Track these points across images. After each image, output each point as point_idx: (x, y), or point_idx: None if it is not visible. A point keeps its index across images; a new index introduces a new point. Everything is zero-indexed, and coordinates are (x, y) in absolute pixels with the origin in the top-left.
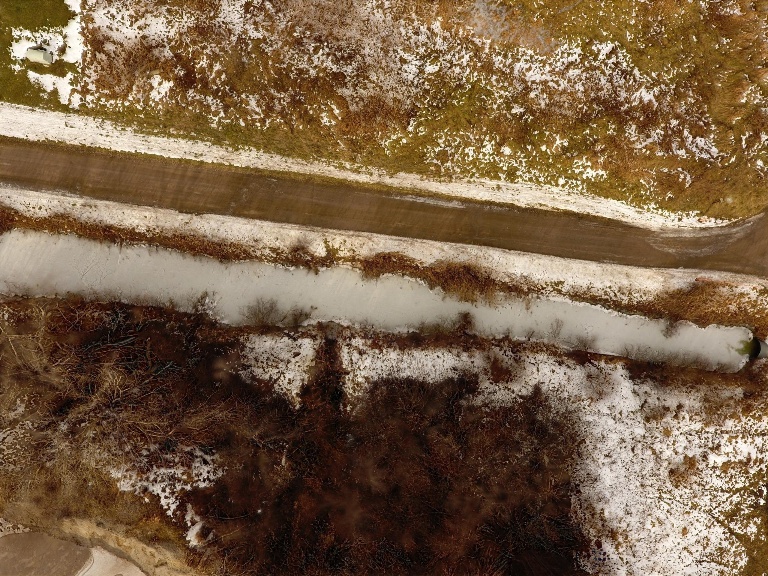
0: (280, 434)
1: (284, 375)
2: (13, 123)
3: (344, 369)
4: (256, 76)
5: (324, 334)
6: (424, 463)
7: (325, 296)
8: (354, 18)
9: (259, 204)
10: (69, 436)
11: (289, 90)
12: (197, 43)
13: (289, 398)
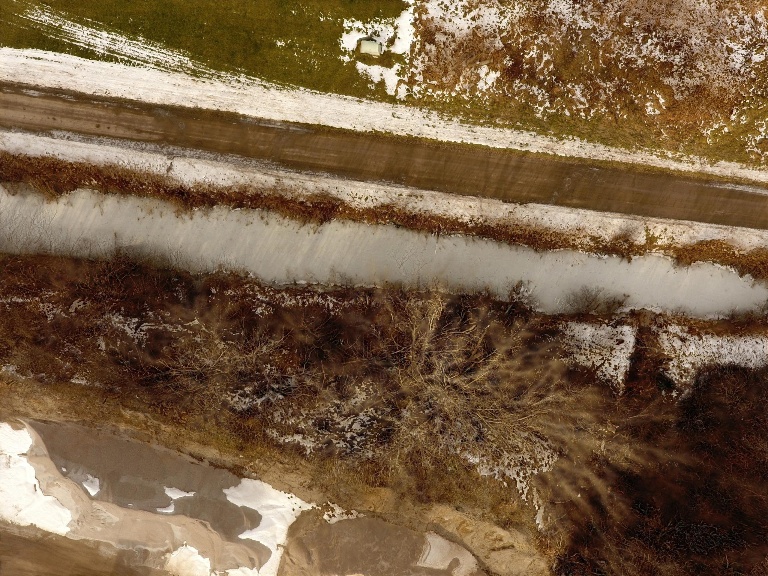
0: (600, 420)
1: (610, 362)
2: (341, 114)
3: (666, 355)
4: (583, 66)
5: (638, 321)
6: (743, 447)
7: (637, 284)
8: (681, 8)
9: (581, 193)
10: (416, 423)
11: (615, 80)
12: (528, 33)
13: (613, 384)
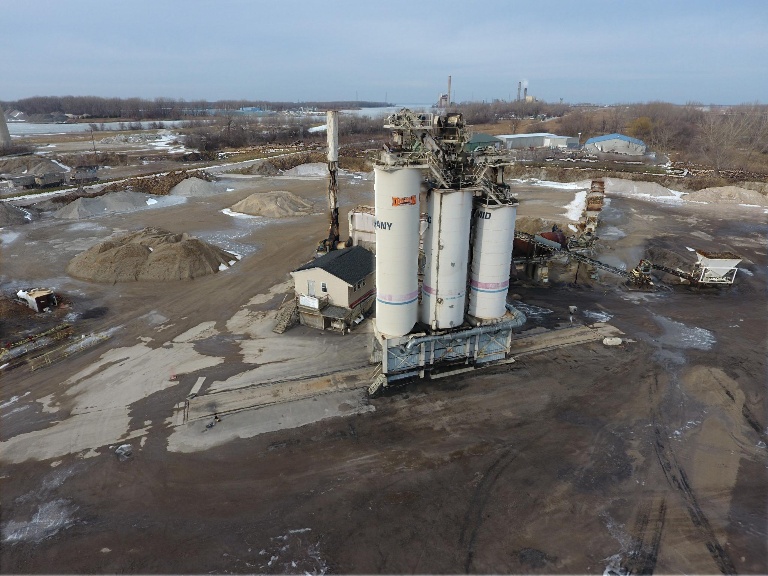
0: None
1: None
2: None
3: None
4: None
5: None
6: None
7: None
8: None
9: None
10: None
11: (765, 177)
12: None
13: None
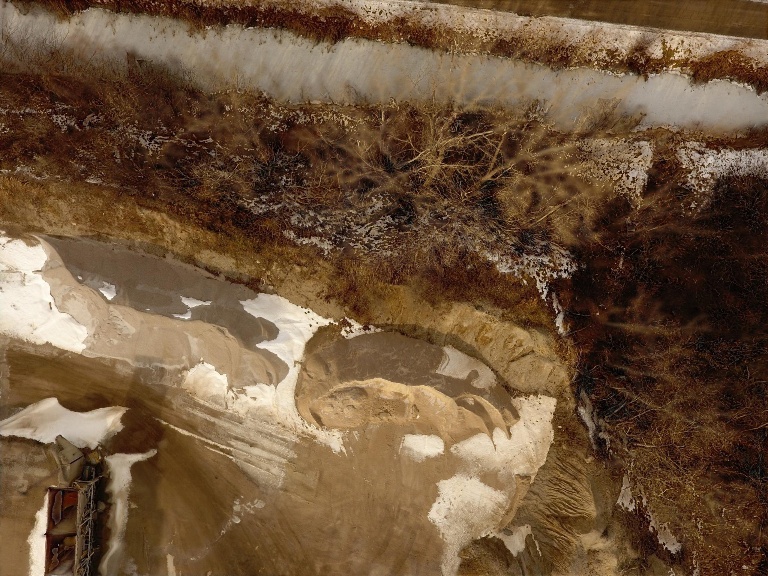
0: (618, 237)
1: (628, 174)
2: None
3: (685, 169)
4: None
5: (655, 139)
6: (762, 262)
7: (654, 102)
8: None
9: (597, 6)
10: (434, 228)
11: None
12: None
13: (632, 198)
